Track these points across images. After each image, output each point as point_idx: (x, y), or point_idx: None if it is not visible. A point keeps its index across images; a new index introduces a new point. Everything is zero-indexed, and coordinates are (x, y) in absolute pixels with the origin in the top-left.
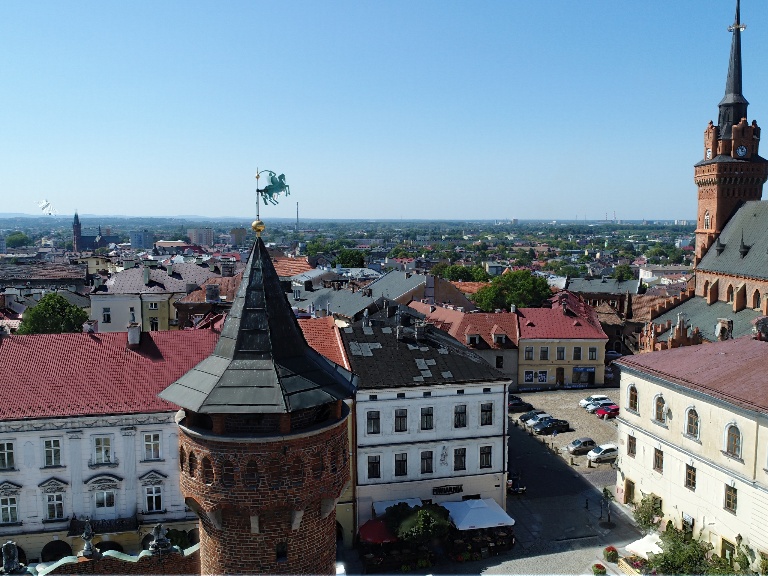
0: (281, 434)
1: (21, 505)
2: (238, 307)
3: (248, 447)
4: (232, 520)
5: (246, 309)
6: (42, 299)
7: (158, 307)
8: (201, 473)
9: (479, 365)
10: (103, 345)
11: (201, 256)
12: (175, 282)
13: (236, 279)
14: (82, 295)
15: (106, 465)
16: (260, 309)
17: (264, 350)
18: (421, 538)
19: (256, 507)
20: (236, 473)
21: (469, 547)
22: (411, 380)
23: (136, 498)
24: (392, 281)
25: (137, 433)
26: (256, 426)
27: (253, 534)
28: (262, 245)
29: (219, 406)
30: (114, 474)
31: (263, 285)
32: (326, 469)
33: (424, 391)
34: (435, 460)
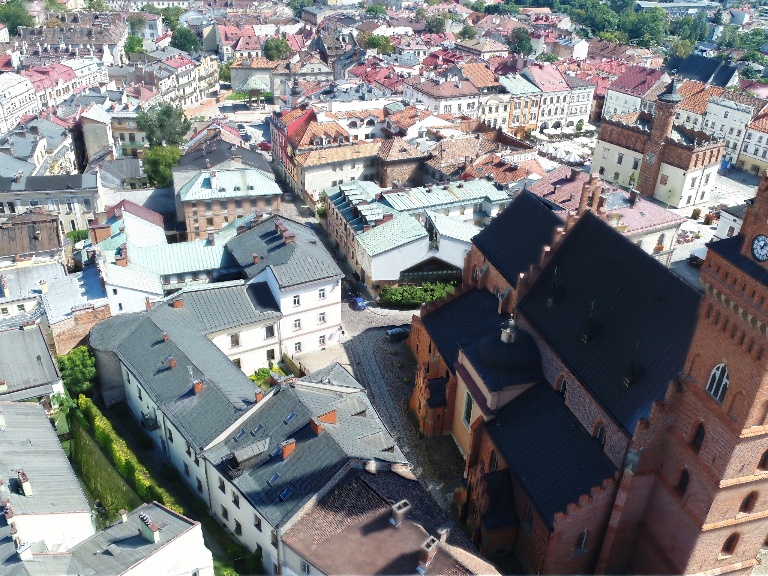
0: None
1: None
2: None
3: None
4: None
5: None
6: None
7: None
8: None
9: (742, 206)
10: None
11: None
12: None
13: None
14: None
15: None
16: None
17: None
18: None
19: None
20: None
21: None
22: None
23: None
24: None
25: None
26: None
27: None
28: None
29: None
30: None
31: None
32: None
33: None
34: None
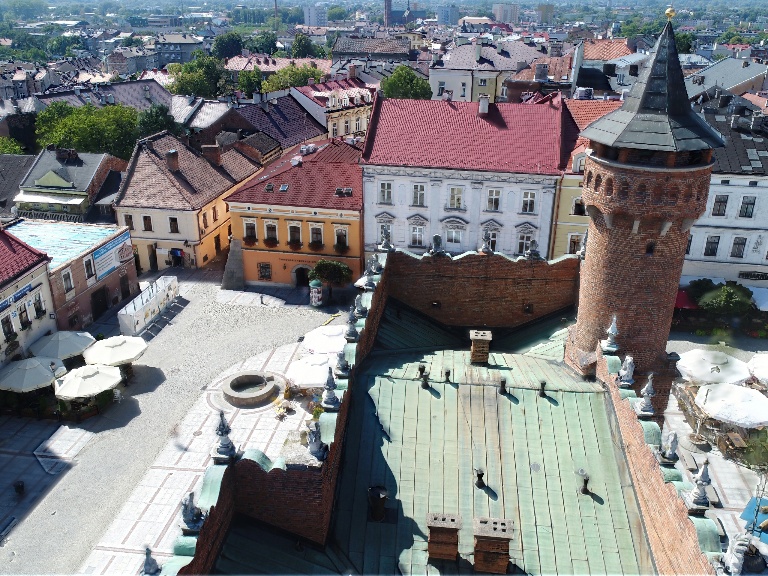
0: (667, 167)
1: (394, 231)
2: (644, 75)
3: (642, 174)
4: (620, 223)
5: (651, 77)
6: (396, 70)
7: (487, 84)
8: (604, 189)
9: None
10: (459, 112)
11: (511, 35)
12: (503, 60)
13: (565, 59)
14: (414, 69)
15: (457, 210)
16: (662, 77)
17: (661, 108)
18: (721, 309)
19: (640, 215)
20: (630, 190)
21: (767, 326)
22: (739, 168)
23: (477, 239)
24: (725, 70)
25: (483, 187)
26: (646, 162)
27: (633, 234)
28: (670, 27)
29: (627, 143)
30: (462, 218)
31: (667, 59)
32: (693, 197)
33: (750, 180)
34: (748, 247)
